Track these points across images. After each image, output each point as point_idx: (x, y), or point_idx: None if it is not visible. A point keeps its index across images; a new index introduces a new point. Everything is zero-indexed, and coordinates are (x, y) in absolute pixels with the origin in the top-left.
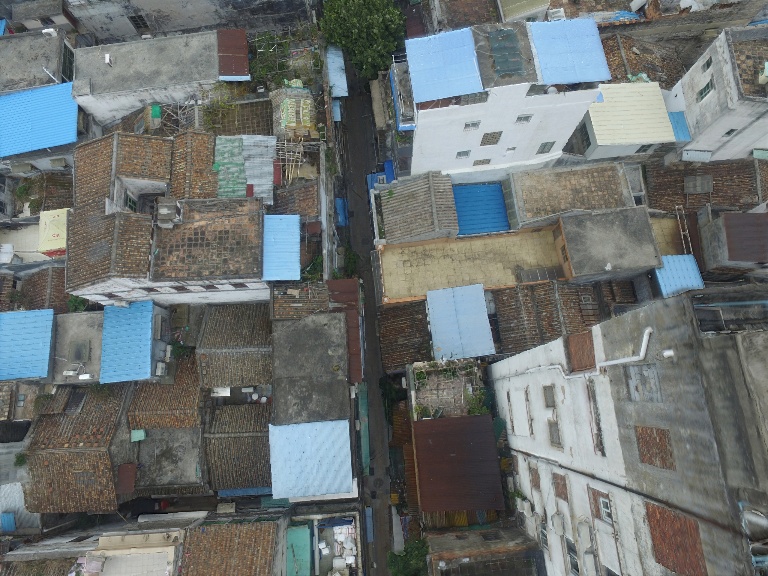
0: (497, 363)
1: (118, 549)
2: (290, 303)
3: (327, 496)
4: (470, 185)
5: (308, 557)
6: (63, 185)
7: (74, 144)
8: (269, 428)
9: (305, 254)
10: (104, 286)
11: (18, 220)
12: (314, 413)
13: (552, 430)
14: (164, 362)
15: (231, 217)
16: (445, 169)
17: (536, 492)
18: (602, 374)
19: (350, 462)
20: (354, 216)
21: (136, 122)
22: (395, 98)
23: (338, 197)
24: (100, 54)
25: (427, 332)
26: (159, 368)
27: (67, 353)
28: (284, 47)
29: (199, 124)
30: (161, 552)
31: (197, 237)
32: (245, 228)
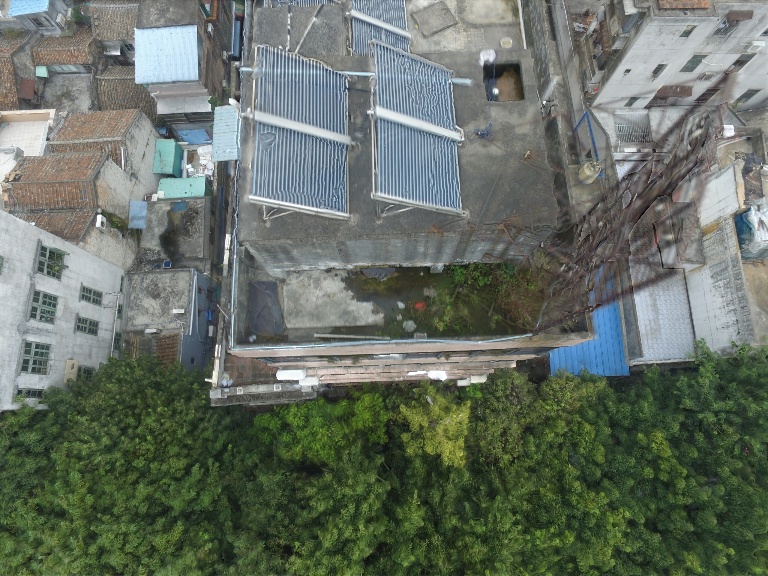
0: None
1: None
2: None
3: (187, 110)
4: None
5: (172, 159)
6: None
7: None
8: (135, 32)
9: None
10: None
11: None
12: (170, 20)
13: None
14: (65, 18)
15: None
16: None
17: None
18: None
19: (197, 58)
20: None
21: None
22: None
23: None
24: None
25: None
26: (59, 17)
27: None
28: None
29: None
30: (45, 112)
31: None
32: None
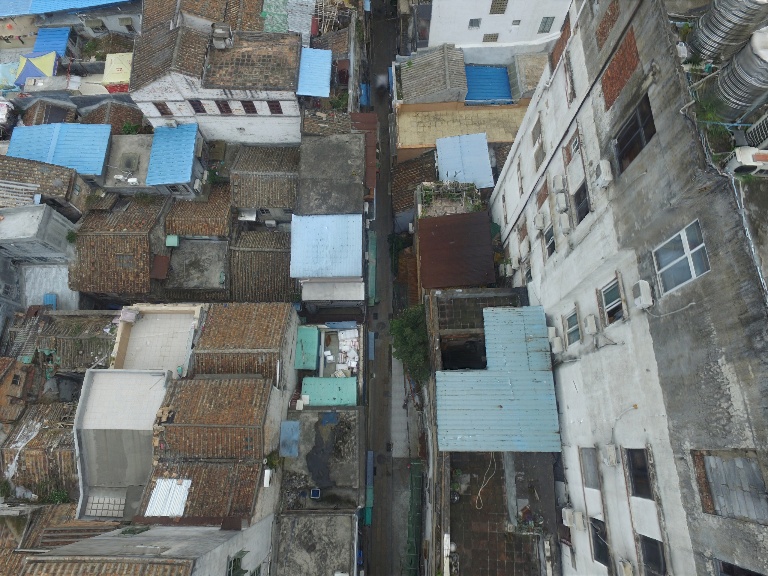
0: (495, 186)
1: (151, 306)
2: (318, 123)
3: (336, 297)
4: (479, 66)
5: (315, 352)
6: (126, 45)
7: (141, 6)
8: None
9: None
10: (162, 87)
11: (86, 64)
12: (332, 207)
13: (538, 159)
14: (201, 182)
15: (274, 46)
16: (458, 43)
17: (523, 242)
18: (575, 34)
19: (361, 251)
20: (374, 110)
21: None
22: None
23: (362, 83)
24: None
25: (434, 177)
26: (197, 183)
27: (118, 164)
28: None
29: None
30: (188, 310)
31: (244, 58)
32: (285, 54)
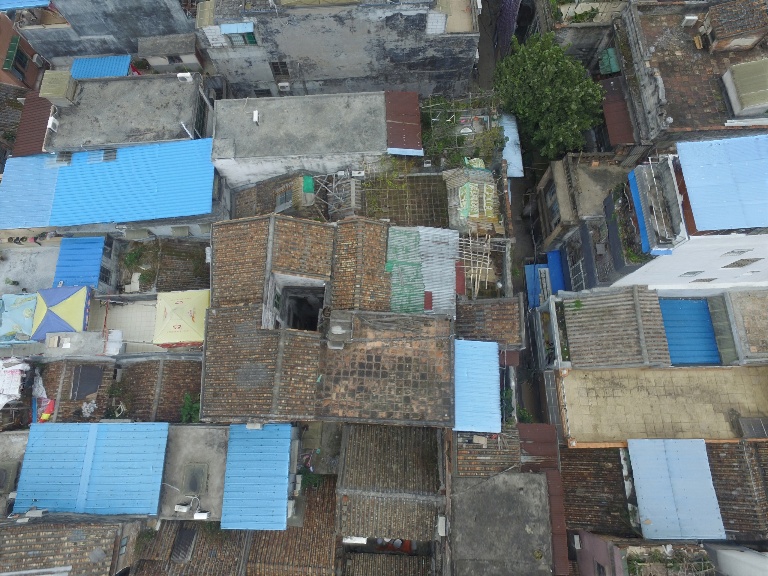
0: (741, 561)
1: None
2: (476, 455)
3: None
4: (670, 299)
5: None
6: (179, 254)
7: None
8: None
9: (503, 395)
10: None
11: (127, 296)
12: None
13: None
14: (293, 498)
15: (414, 339)
16: (654, 284)
17: None
18: None
19: None
20: None
21: (279, 192)
22: (643, 210)
23: None
24: (245, 109)
25: (620, 488)
26: (290, 508)
27: (179, 478)
28: (456, 115)
29: (356, 202)
30: None
31: (371, 363)
32: (432, 356)
